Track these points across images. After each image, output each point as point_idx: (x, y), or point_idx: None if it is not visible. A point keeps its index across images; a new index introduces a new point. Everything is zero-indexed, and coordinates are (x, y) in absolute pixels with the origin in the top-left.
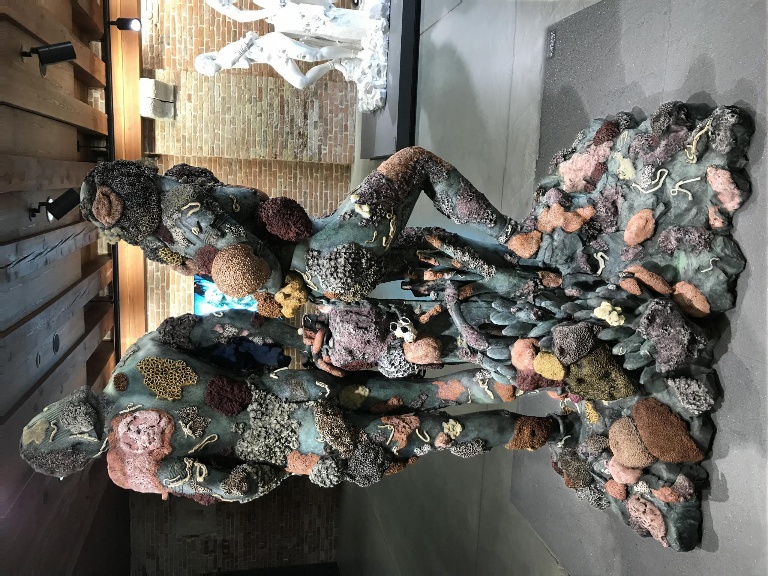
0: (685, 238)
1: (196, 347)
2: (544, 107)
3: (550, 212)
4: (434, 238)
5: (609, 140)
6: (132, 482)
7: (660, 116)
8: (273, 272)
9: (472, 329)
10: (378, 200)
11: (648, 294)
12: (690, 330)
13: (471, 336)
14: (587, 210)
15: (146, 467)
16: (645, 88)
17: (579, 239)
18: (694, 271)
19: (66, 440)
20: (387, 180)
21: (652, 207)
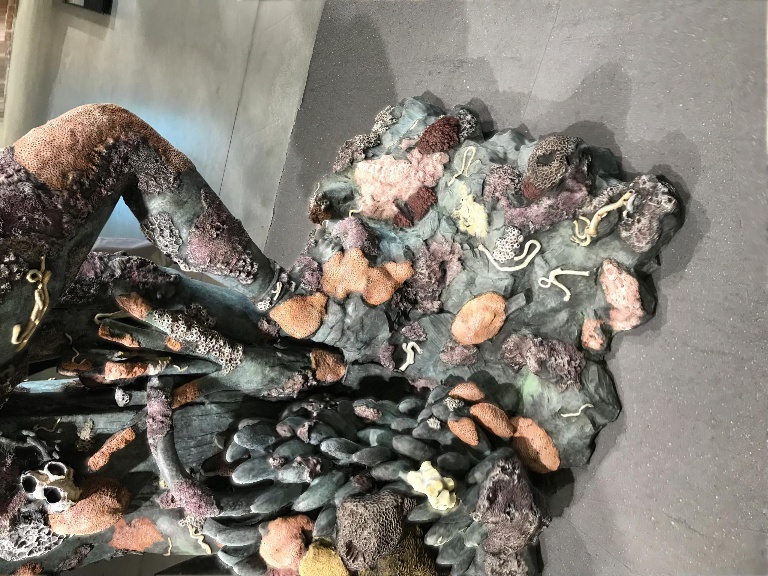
0: (550, 361)
1: None
2: (322, 35)
3: (345, 262)
4: (135, 301)
5: (443, 151)
6: None
7: (551, 156)
8: None
9: (193, 486)
10: (7, 239)
11: (486, 443)
12: (539, 513)
13: (190, 500)
14: (402, 269)
15: None
16: (499, 76)
17: (386, 319)
18: (552, 413)
19: None
20: (36, 187)
21: (504, 293)
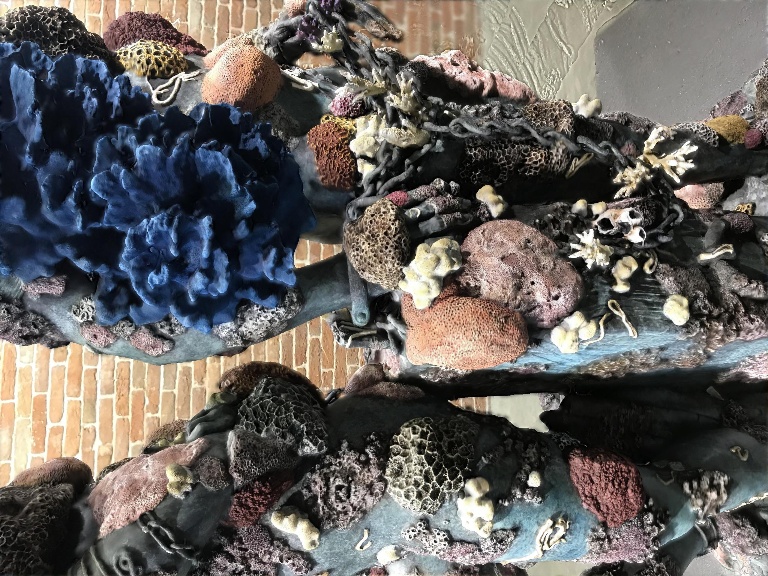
0: None
1: None
2: None
3: None
4: None
5: None
6: None
7: None
8: None
9: None
10: None
11: None
12: None
13: None
14: None
15: None
16: None
17: None
18: None
19: None
20: None
21: None
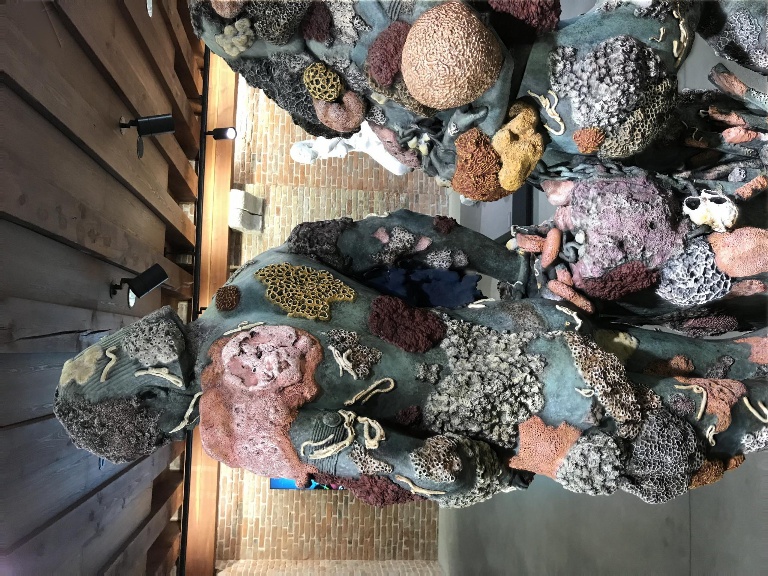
0: None
1: (345, 266)
2: None
3: None
4: (734, 78)
5: None
6: (241, 451)
7: None
8: (506, 63)
9: None
10: None
11: None
12: None
13: None
14: None
15: (270, 419)
16: None
17: None
18: None
19: (129, 380)
20: None
21: None
